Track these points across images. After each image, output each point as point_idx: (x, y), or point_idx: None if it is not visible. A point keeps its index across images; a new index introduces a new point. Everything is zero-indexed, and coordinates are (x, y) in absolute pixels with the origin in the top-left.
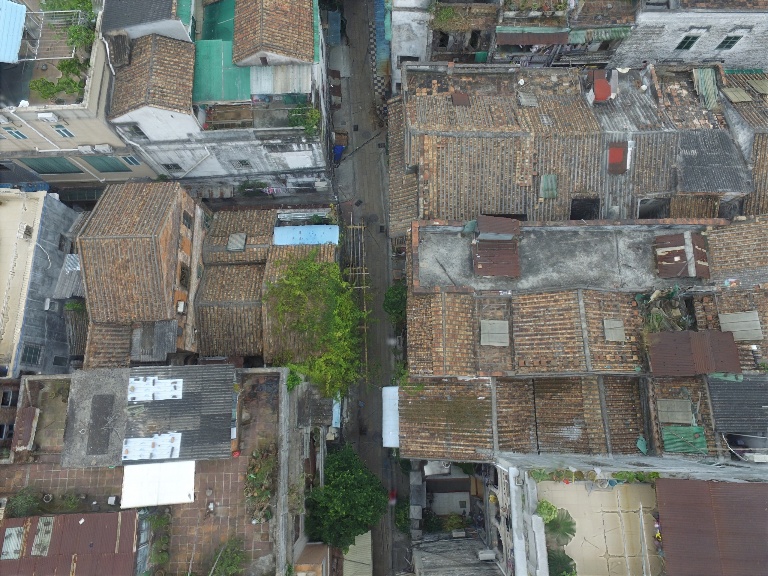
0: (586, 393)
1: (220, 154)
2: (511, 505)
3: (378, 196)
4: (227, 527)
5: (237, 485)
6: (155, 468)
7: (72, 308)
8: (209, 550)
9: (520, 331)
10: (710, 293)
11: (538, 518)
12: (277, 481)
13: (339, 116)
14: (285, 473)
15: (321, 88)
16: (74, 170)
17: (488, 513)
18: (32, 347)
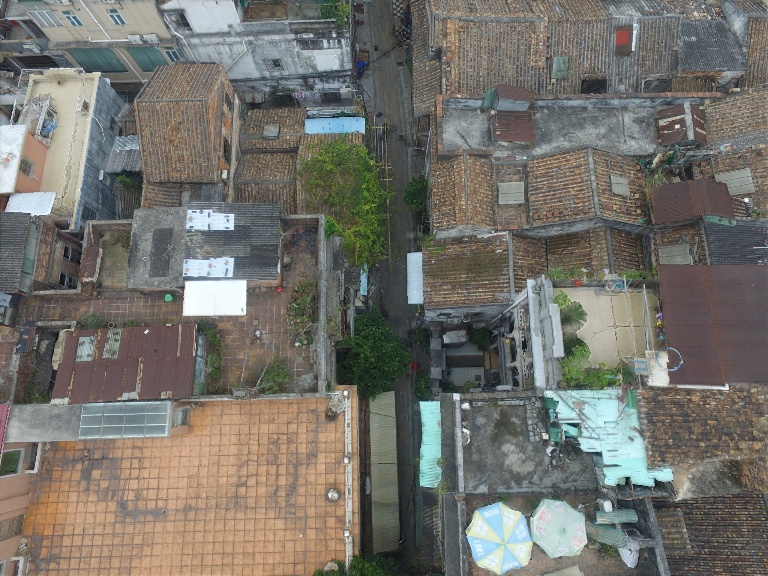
0: (594, 244)
1: (256, 51)
2: (529, 309)
3: (397, 109)
4: (272, 351)
5: (280, 316)
6: (212, 285)
7: (122, 183)
8: (256, 370)
9: (535, 190)
10: (707, 158)
11: (554, 305)
12: (318, 307)
13: (360, 37)
14: (324, 305)
15: None
16: (119, 69)
17: (503, 364)
18: (89, 209)
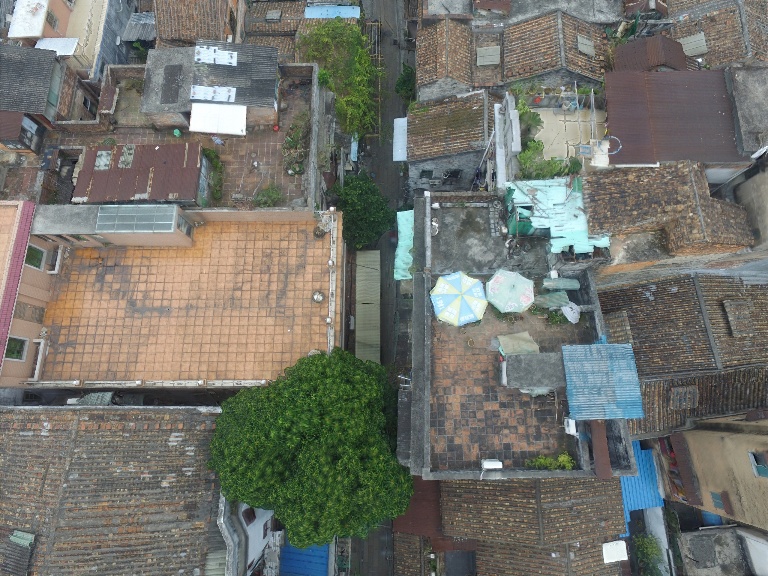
0: None
1: None
2: (495, 127)
3: (393, 16)
4: (268, 179)
5: (276, 151)
6: (216, 108)
7: None
8: None
9: (509, 52)
10: (667, 27)
11: (515, 111)
12: (310, 138)
13: None
14: (315, 141)
15: None
16: None
17: None
18: None
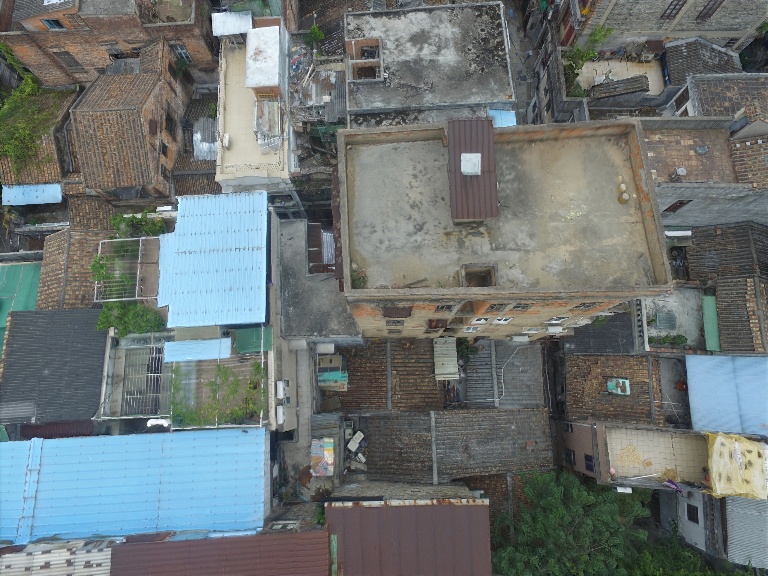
0: None
1: None
2: None
3: None
4: None
5: None
6: None
7: None
8: None
9: None
10: None
11: None
12: None
13: None
14: None
15: None
16: None
17: None
18: None
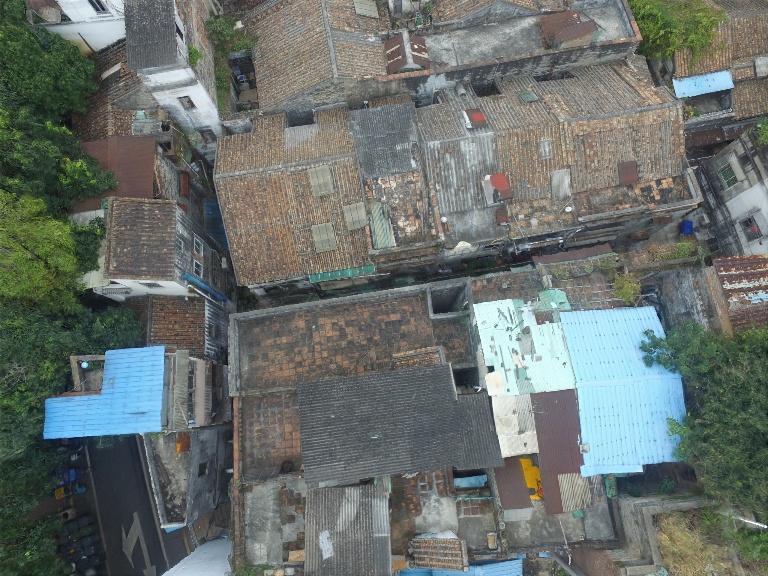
0: None
1: None
2: None
3: None
4: None
5: None
6: None
7: None
8: None
9: None
10: None
11: None
12: None
13: None
14: None
15: (760, 212)
16: None
17: None
18: None
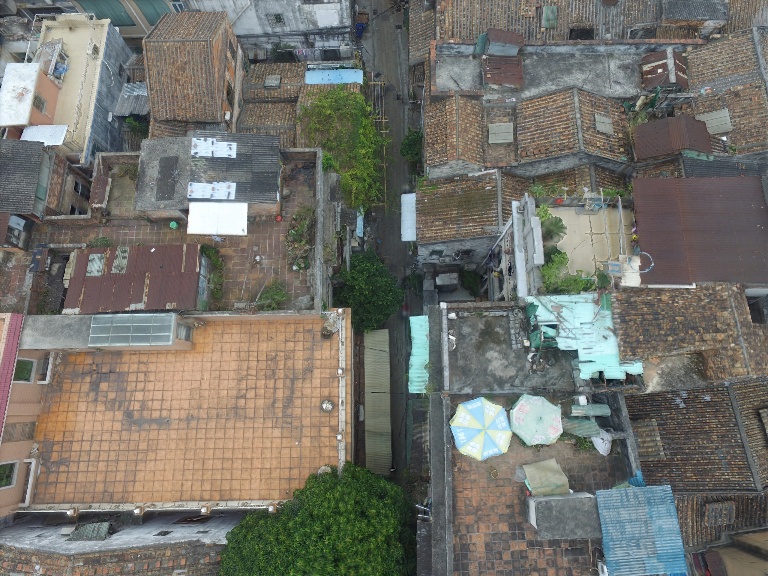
0: (579, 180)
1: (259, 5)
2: (513, 228)
3: (395, 69)
4: (271, 274)
5: (279, 243)
6: (215, 207)
7: None
8: (256, 291)
9: (523, 130)
10: (688, 101)
11: (536, 218)
12: (315, 232)
13: (360, 2)
14: (321, 232)
15: None
16: (127, 23)
17: (492, 299)
18: (99, 147)
